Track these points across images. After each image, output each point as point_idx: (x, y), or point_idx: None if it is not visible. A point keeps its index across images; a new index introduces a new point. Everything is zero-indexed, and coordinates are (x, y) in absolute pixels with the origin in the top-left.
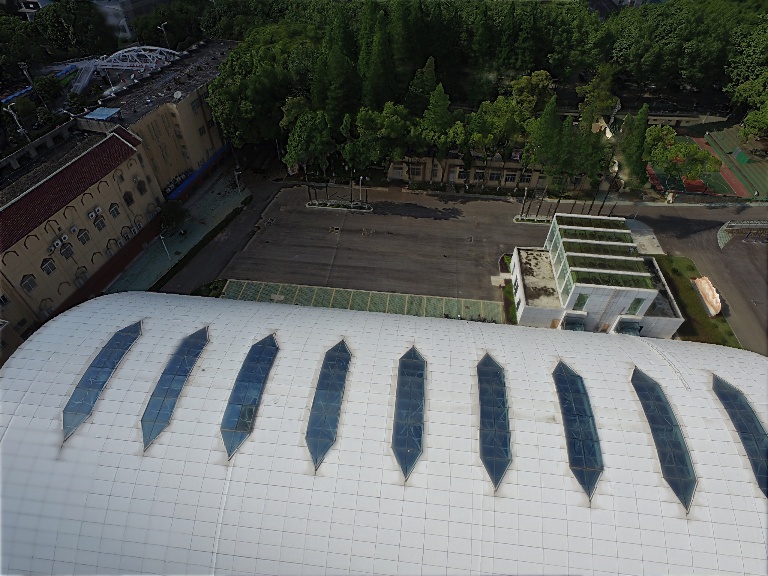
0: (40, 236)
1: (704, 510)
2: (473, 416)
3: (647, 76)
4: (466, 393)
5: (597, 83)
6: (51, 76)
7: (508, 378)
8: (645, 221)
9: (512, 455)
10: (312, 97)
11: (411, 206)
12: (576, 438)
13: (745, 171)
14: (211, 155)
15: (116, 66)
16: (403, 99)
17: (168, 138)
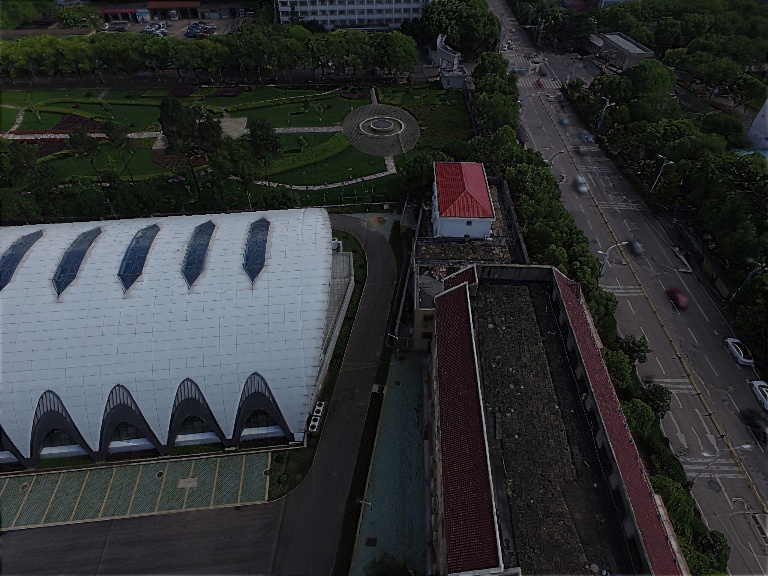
0: None
1: None
2: None
3: None
4: None
5: None
6: None
7: None
8: None
9: None
10: None
11: None
12: None
13: None
14: None
15: None
16: None
17: None
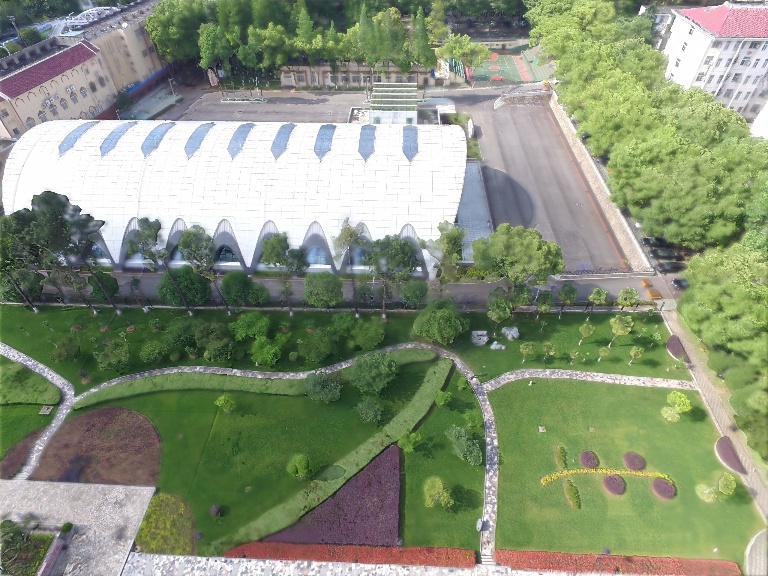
0: (37, 95)
1: (374, 161)
2: (272, 137)
3: (468, 9)
4: (271, 131)
5: (434, 16)
6: (32, 28)
7: (297, 127)
8: (451, 98)
9: (287, 148)
10: (220, 24)
11: (295, 99)
12: (321, 141)
13: (535, 70)
14: (153, 73)
15: (82, 23)
16: (287, 26)
17: (120, 55)
